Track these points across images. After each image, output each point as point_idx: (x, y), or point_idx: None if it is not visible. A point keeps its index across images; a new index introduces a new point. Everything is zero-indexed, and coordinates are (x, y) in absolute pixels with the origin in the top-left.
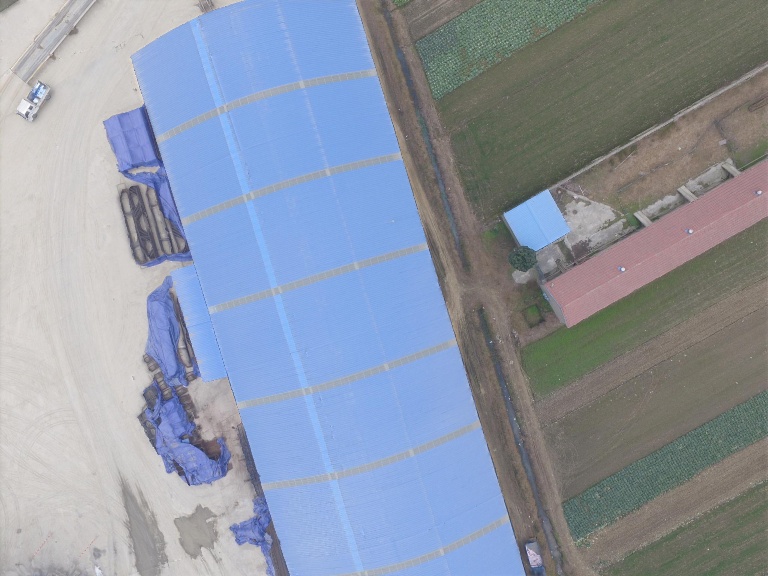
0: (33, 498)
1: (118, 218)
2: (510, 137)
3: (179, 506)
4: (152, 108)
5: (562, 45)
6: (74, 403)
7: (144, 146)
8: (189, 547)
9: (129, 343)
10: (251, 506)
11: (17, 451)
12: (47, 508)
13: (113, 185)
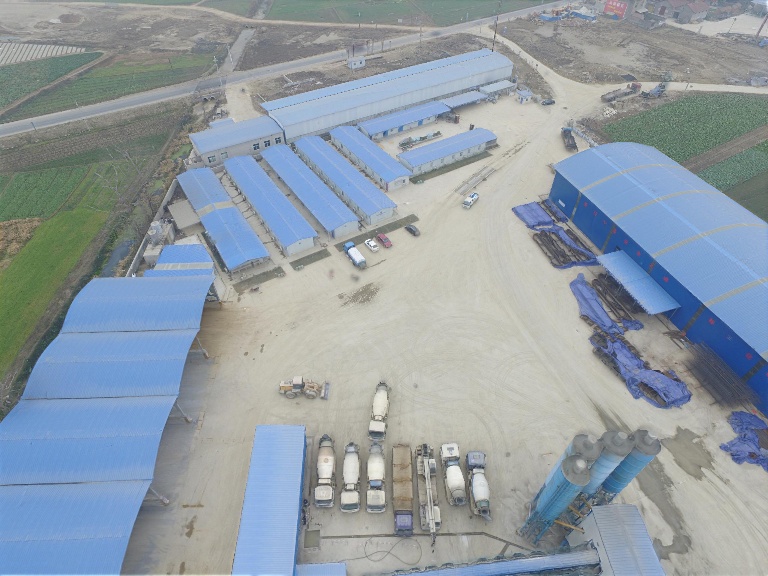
0: (515, 423)
1: (534, 247)
2: (761, 213)
3: (659, 428)
4: (573, 180)
5: (759, 183)
6: (533, 348)
7: (542, 216)
8: (688, 468)
9: (565, 310)
10: (729, 427)
11: (492, 384)
12: (531, 432)
13: (525, 233)
